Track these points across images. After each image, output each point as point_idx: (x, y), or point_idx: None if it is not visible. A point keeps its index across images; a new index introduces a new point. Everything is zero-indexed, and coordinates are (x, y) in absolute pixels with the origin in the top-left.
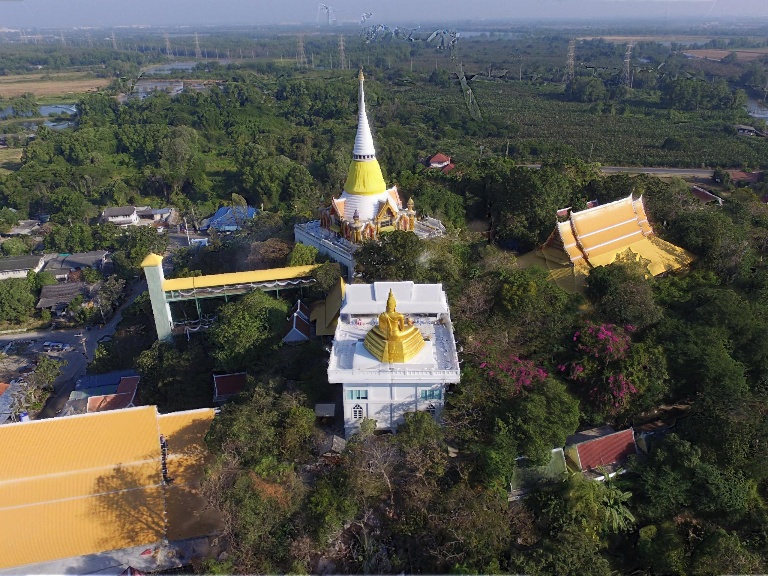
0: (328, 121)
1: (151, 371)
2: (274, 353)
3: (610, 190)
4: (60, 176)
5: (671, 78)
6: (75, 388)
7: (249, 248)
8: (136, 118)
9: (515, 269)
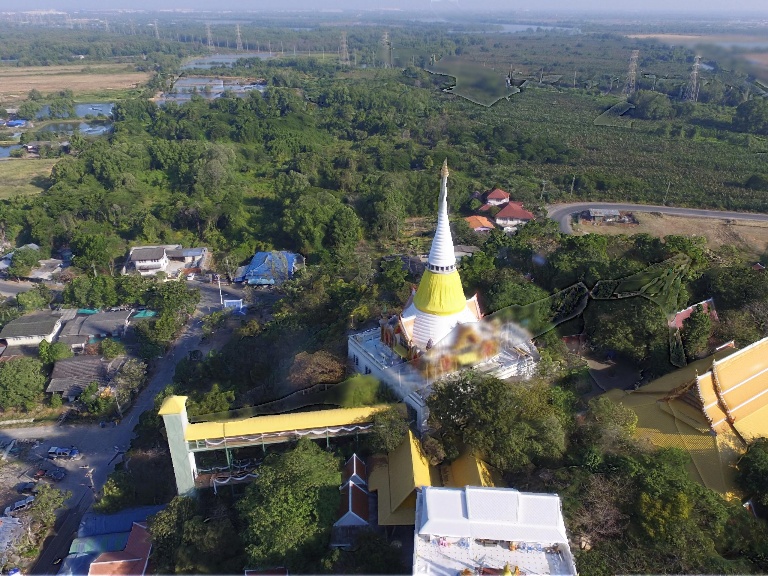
0: (373, 137)
1: (167, 541)
2: (326, 572)
3: (730, 288)
4: (88, 203)
5: (741, 93)
6: (78, 531)
7: (290, 334)
8: (173, 126)
9: (646, 451)
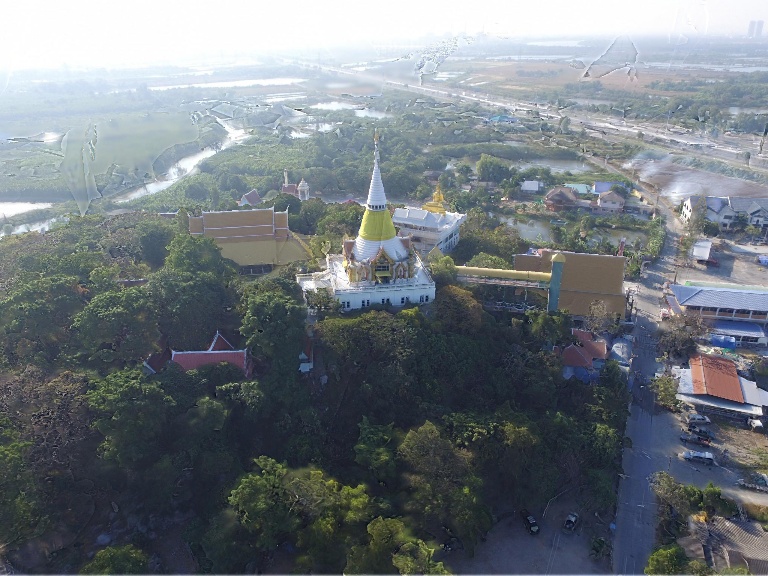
0: None
1: None
2: None
3: None
4: None
5: None
6: None
7: None
8: None
9: (338, 221)
